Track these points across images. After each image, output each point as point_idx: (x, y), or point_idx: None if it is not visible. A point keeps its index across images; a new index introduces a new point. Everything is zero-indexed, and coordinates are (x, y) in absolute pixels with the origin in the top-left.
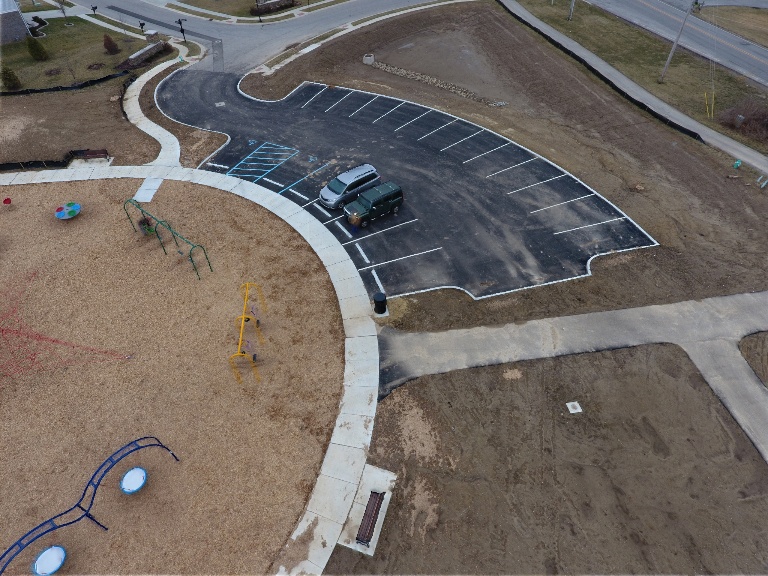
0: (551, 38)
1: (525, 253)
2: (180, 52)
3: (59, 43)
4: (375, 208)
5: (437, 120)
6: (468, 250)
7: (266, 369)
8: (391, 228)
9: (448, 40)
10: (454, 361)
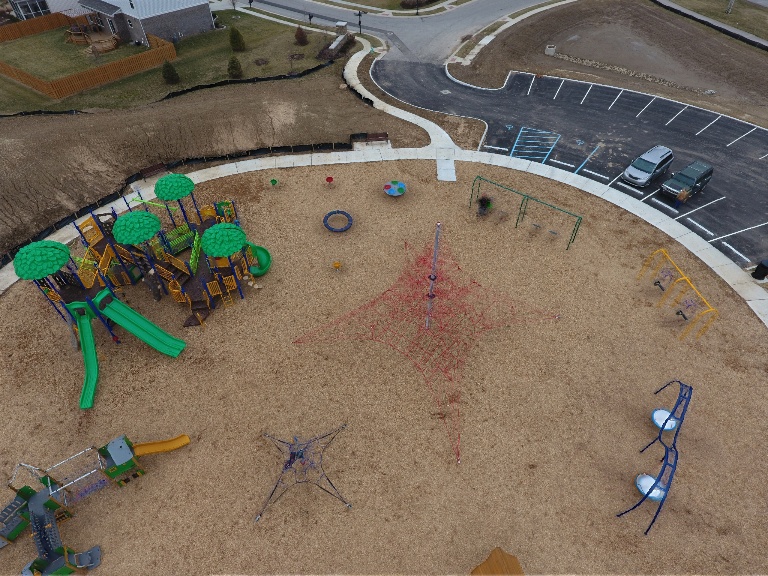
0: (727, 30)
1: None
2: (363, 43)
3: (244, 34)
4: (699, 185)
5: (669, 107)
6: None
7: (694, 327)
8: (708, 204)
9: (610, 32)
10: None
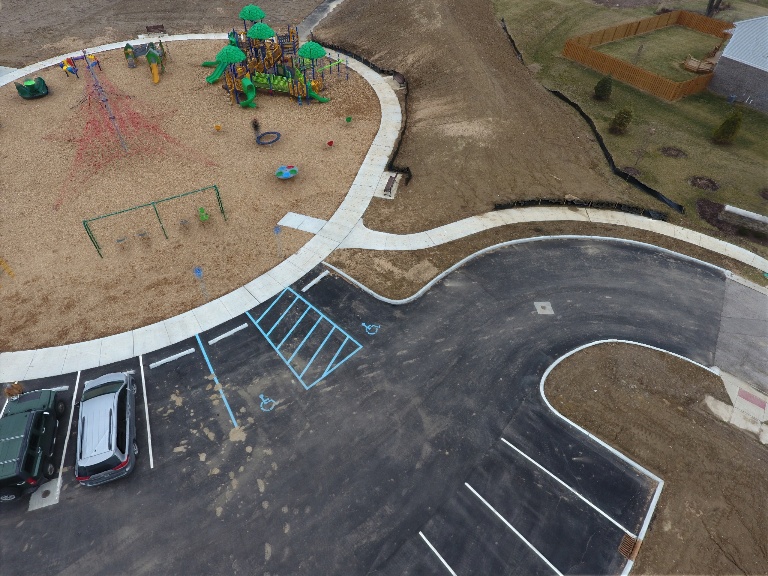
0: None
1: None
2: None
3: None
4: None
5: None
6: None
7: None
8: None
9: None
10: None
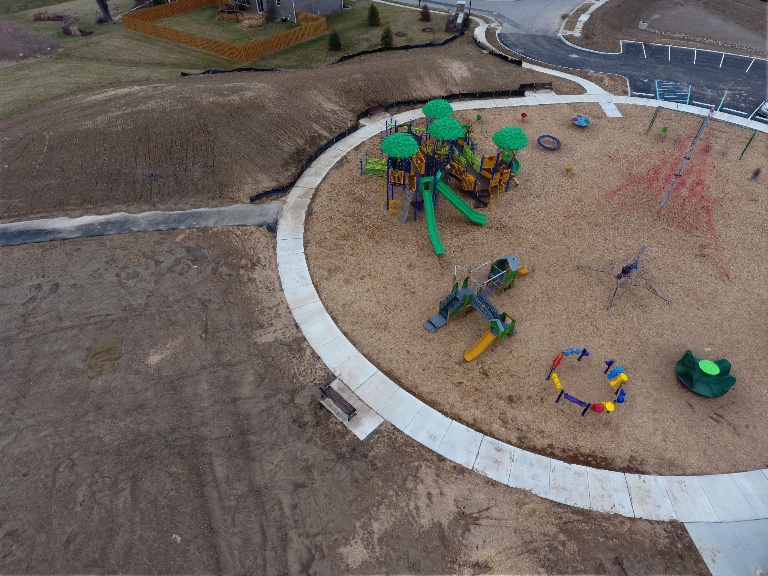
0: None
1: None
2: (477, 20)
3: None
4: None
5: None
6: None
7: None
8: None
9: (687, 12)
10: None
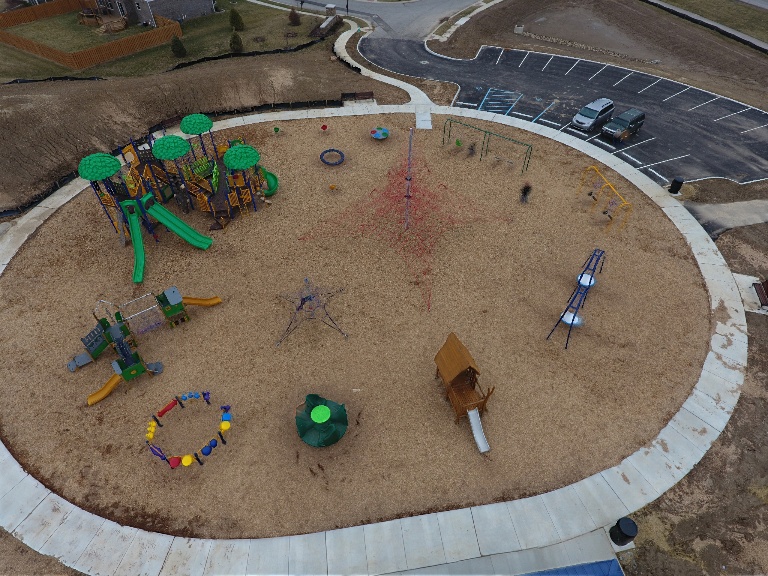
0: (675, 11)
1: (757, 157)
2: (350, 24)
3: (242, 17)
4: (632, 126)
5: (618, 72)
6: (711, 156)
7: (618, 225)
8: (640, 143)
9: (574, 15)
10: (752, 219)
